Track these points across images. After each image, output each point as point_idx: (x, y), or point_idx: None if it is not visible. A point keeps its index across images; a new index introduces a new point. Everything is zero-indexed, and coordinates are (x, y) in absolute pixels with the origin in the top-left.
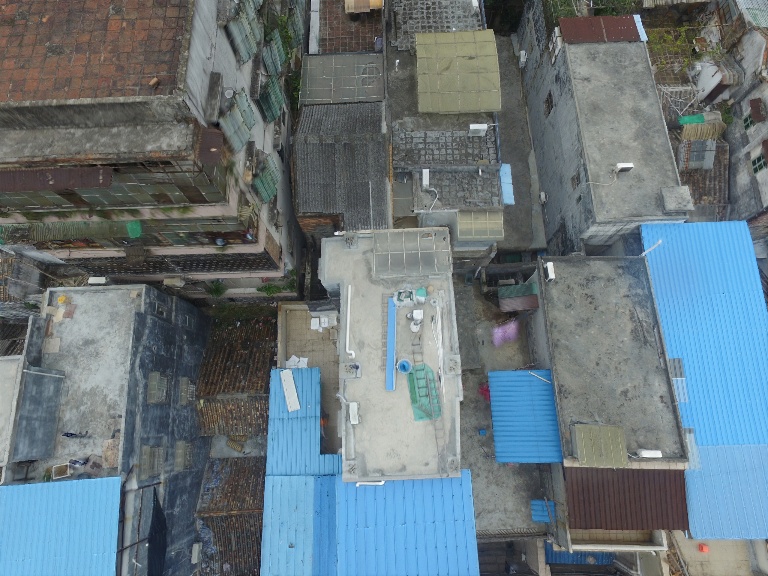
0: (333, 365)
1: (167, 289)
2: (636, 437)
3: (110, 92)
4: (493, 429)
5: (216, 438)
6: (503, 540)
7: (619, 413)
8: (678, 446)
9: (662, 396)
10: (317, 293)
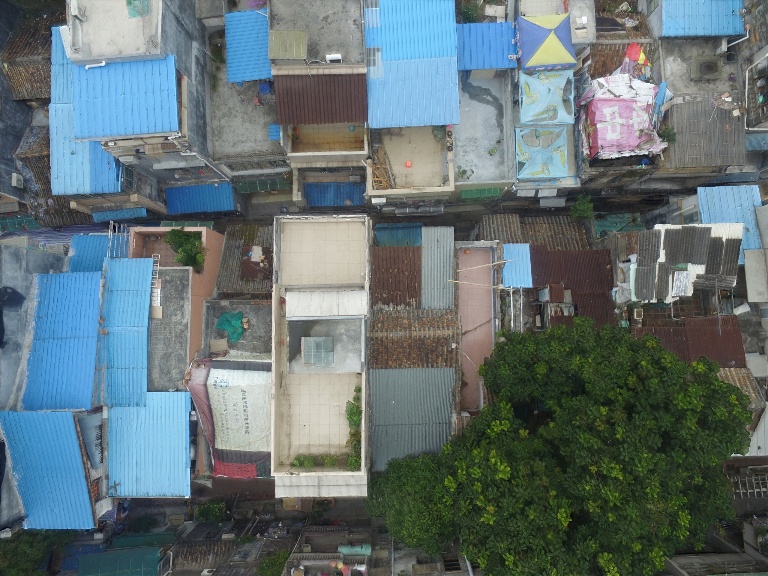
0: None
1: None
2: (330, 51)
3: None
4: (226, 58)
5: (36, 112)
6: (251, 160)
7: (319, 34)
8: (361, 56)
9: (355, 20)
10: None
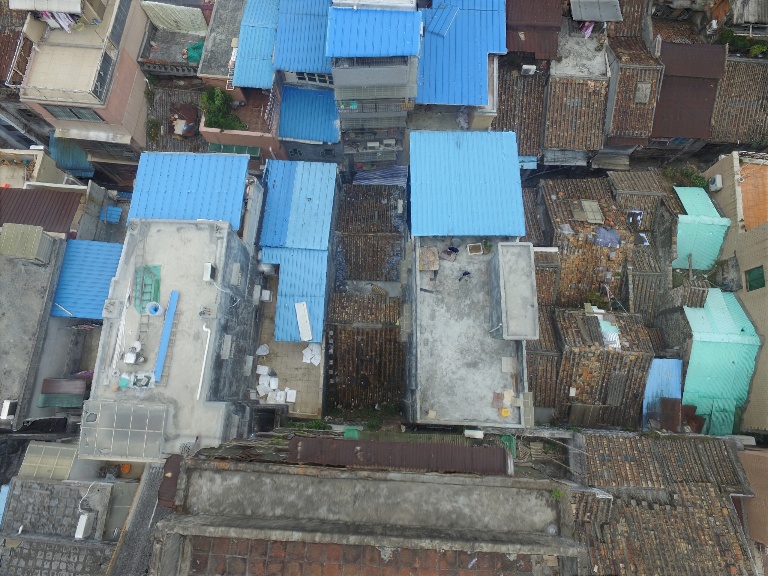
0: (278, 353)
1: (414, 428)
2: None
3: (283, 574)
4: None
5: None
6: None
7: (3, 271)
8: None
9: None
10: (268, 418)
